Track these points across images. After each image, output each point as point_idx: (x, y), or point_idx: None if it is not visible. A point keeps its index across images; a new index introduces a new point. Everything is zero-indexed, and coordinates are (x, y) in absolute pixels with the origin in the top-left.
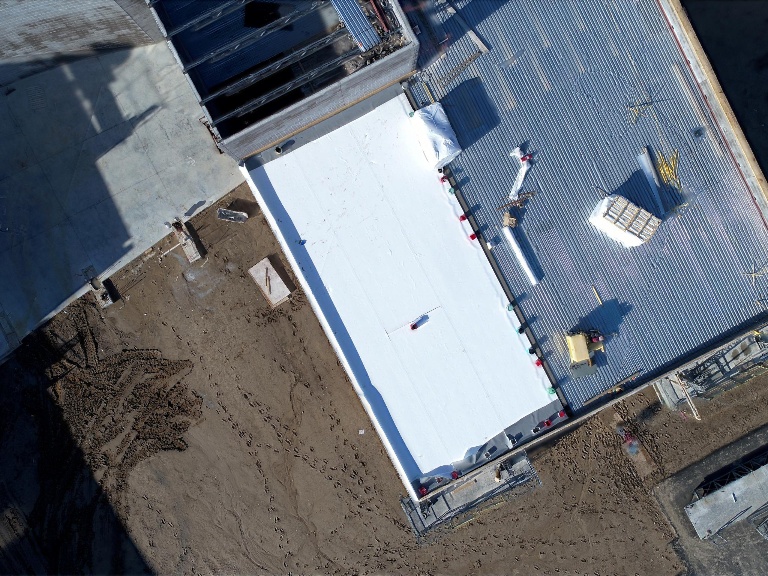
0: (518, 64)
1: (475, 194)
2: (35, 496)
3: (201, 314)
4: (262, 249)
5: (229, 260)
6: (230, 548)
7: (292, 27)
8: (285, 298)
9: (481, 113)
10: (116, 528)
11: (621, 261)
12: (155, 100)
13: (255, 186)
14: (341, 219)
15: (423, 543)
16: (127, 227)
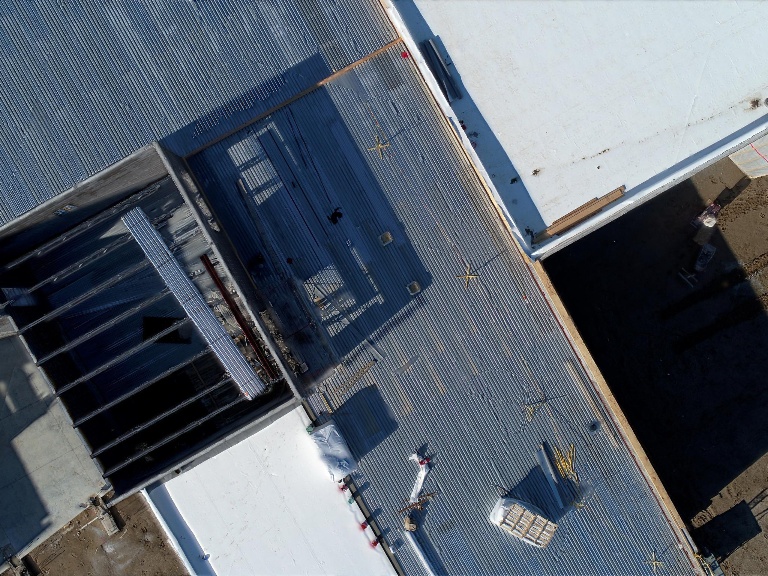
0: (413, 370)
1: (376, 499)
2: None
3: None
4: None
5: (148, 530)
6: None
7: (190, 340)
8: None
9: (378, 419)
10: None
11: (523, 556)
12: None
13: (156, 508)
14: (244, 532)
15: None
16: (44, 504)
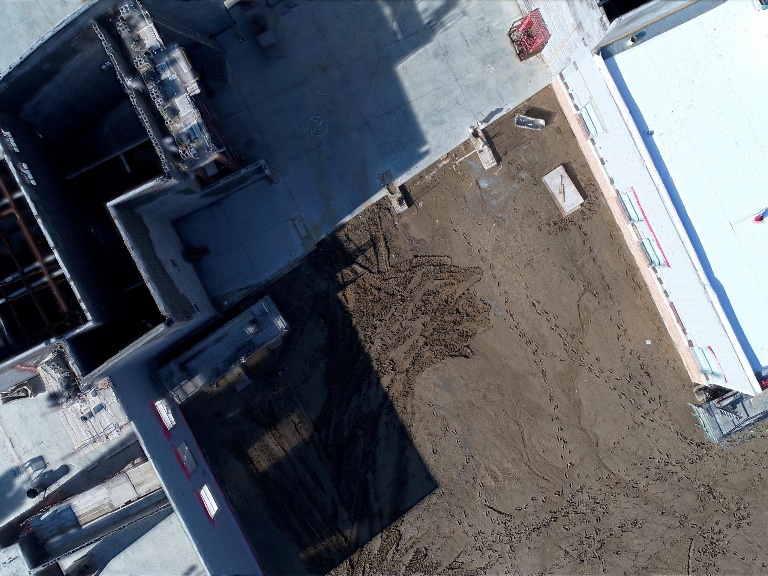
0: None
1: None
2: (322, 401)
3: (493, 221)
4: (555, 157)
5: (522, 168)
6: (512, 457)
7: None
8: (578, 206)
9: None
10: (401, 435)
11: None
12: (456, 8)
13: (610, 75)
14: (689, 111)
15: (705, 456)
16: (425, 133)
